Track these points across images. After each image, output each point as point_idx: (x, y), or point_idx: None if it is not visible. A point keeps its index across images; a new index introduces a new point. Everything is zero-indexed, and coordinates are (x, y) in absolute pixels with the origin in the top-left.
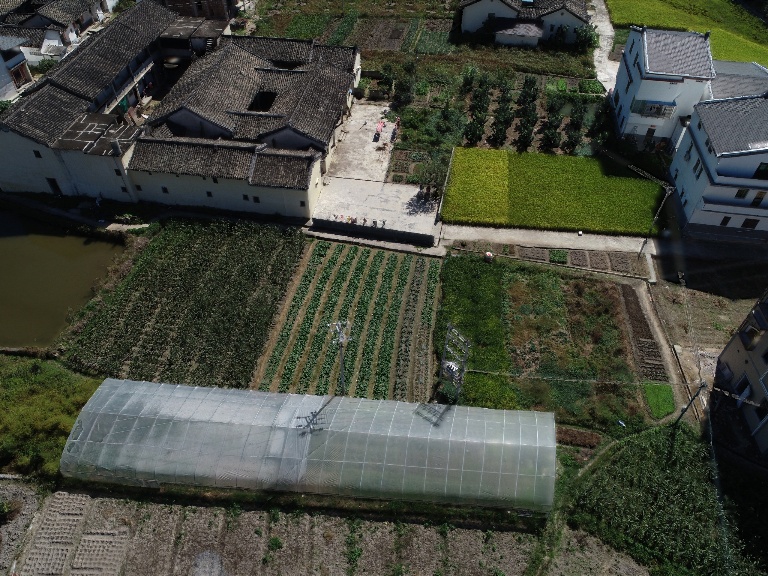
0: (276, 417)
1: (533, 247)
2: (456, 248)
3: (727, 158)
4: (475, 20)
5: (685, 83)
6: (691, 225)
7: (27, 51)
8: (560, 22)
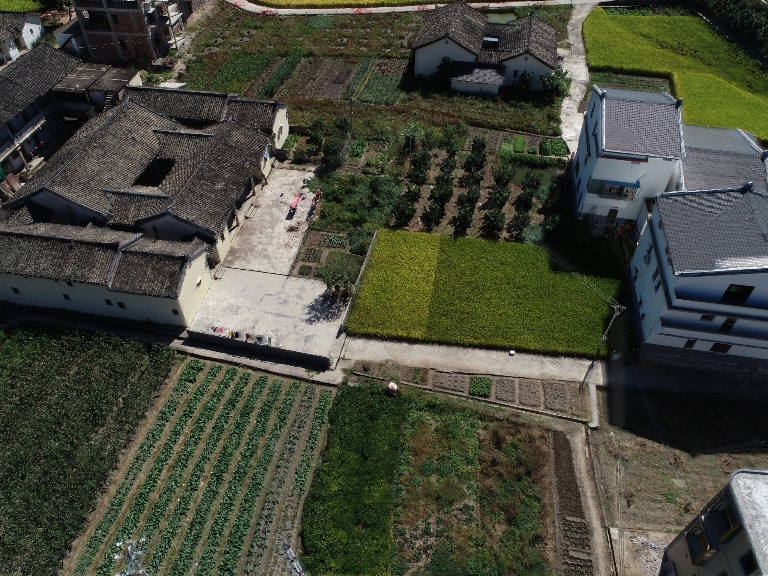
0: None
1: (451, 372)
2: (356, 373)
3: (688, 277)
4: (429, 63)
5: (650, 162)
6: (648, 345)
7: None
8: (524, 68)
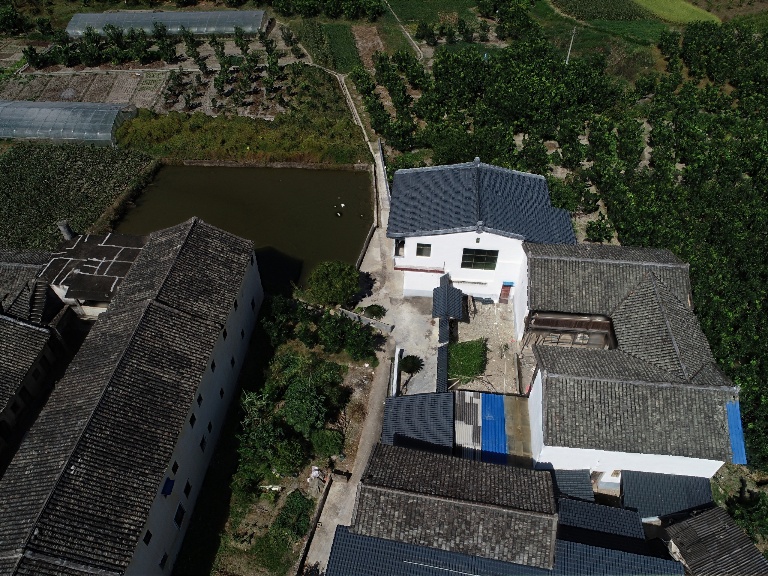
0: (1, 112)
1: None
2: None
3: None
4: None
5: None
6: None
7: None
8: None
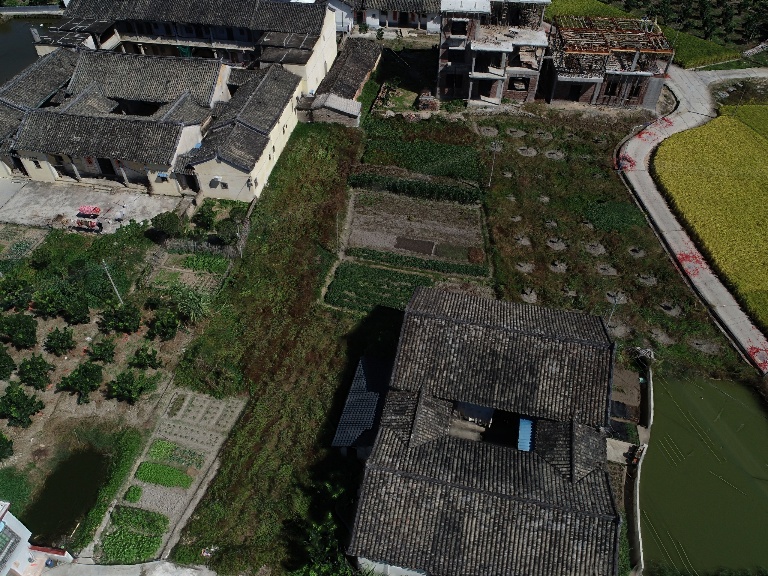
0: None
1: None
2: None
3: None
4: None
5: None
6: None
7: None
8: None
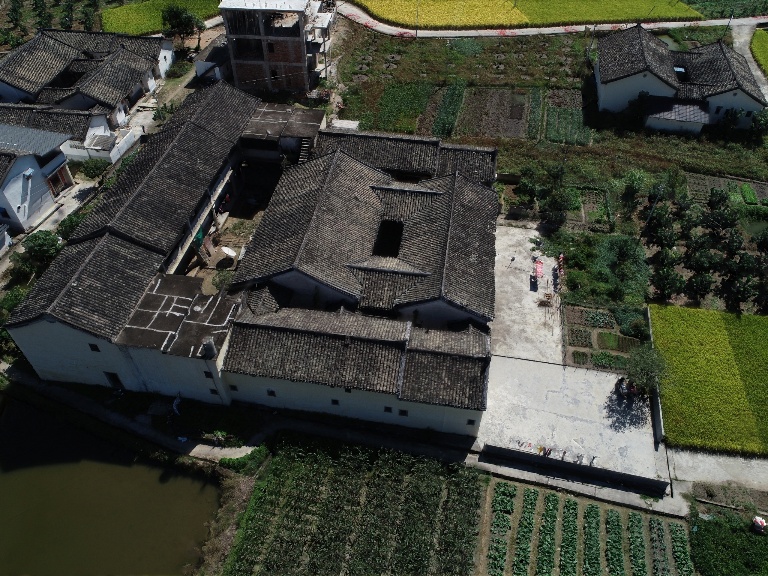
0: None
1: None
2: (700, 499)
3: None
4: (618, 97)
5: None
6: None
7: (67, 144)
8: (730, 104)
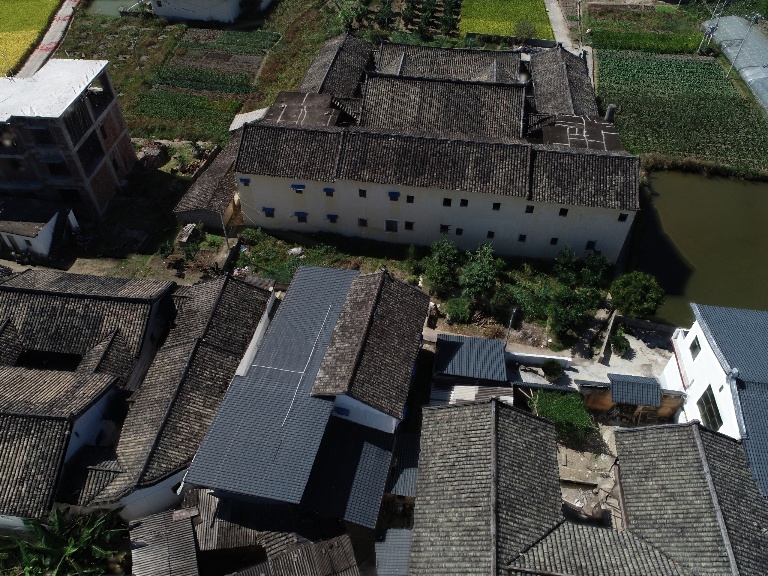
0: None
1: None
2: None
3: None
4: (234, 5)
5: None
6: None
7: None
8: None
